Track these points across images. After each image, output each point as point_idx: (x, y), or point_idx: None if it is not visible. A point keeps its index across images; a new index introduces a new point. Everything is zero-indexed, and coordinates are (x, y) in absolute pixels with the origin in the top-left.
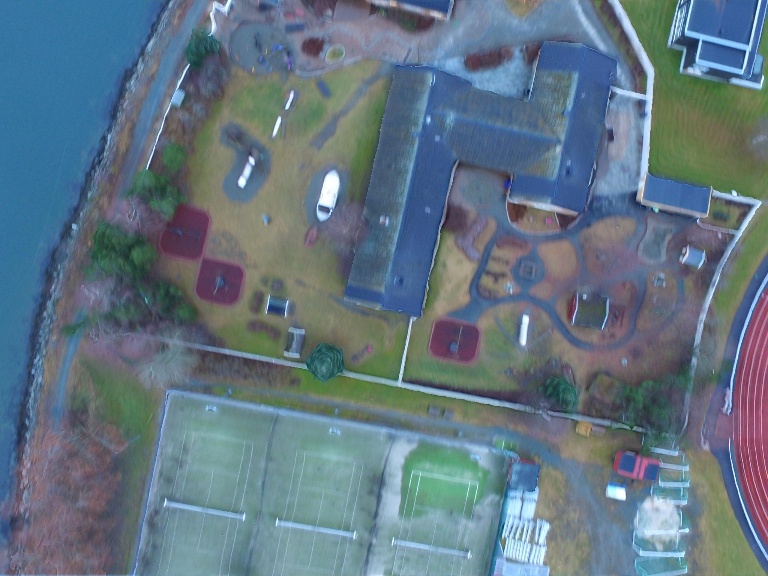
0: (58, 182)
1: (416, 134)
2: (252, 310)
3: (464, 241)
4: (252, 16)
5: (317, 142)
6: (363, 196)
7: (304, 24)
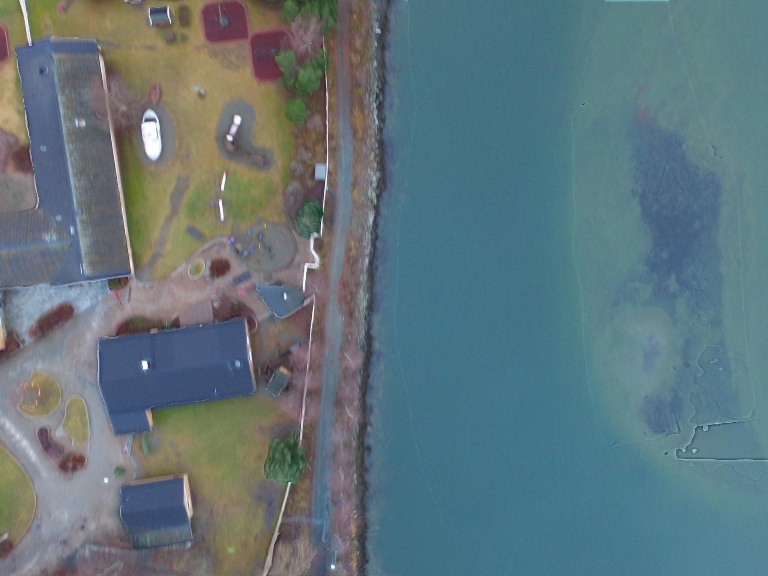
0: (410, 68)
1: (79, 212)
2: (187, 8)
3: (7, 140)
4: (285, 274)
5: (184, 183)
6: (123, 150)
7: (236, 285)
